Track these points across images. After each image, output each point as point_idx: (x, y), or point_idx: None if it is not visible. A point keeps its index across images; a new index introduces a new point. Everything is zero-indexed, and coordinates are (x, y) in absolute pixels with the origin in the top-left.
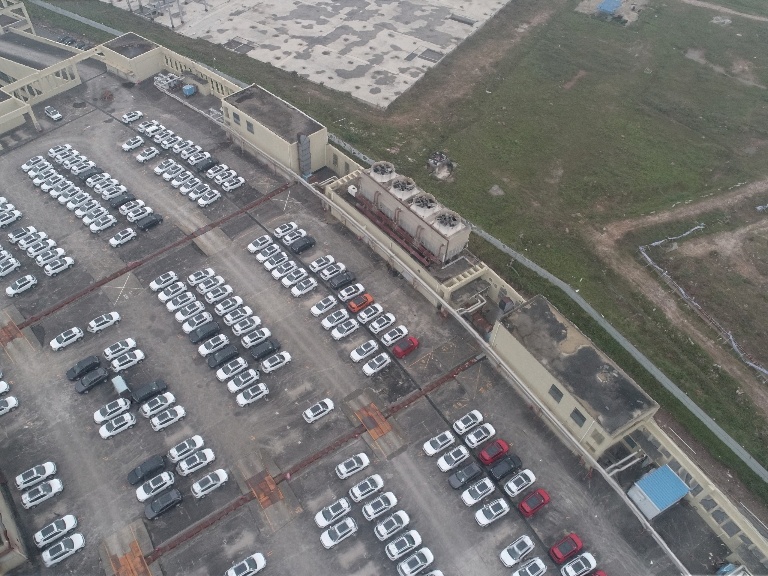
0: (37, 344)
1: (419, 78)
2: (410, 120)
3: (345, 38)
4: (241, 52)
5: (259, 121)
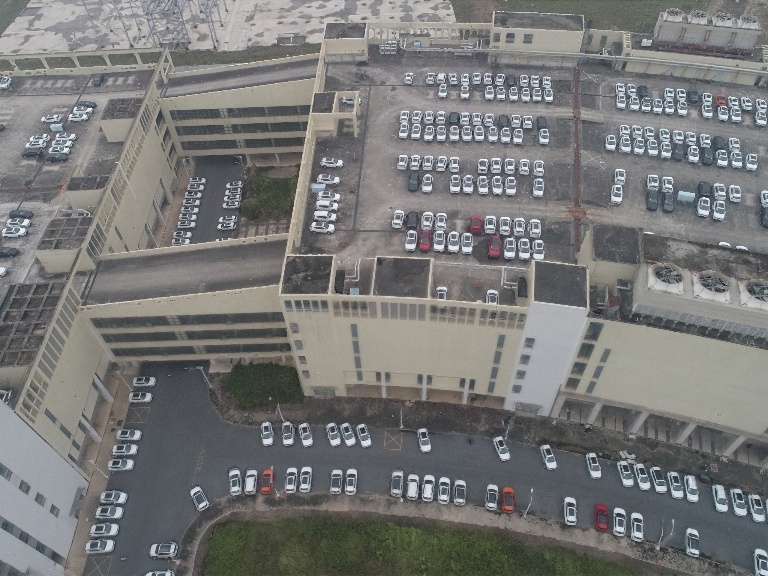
0: (602, 208)
1: (452, 9)
2: None
3: (362, 3)
4: None
5: None
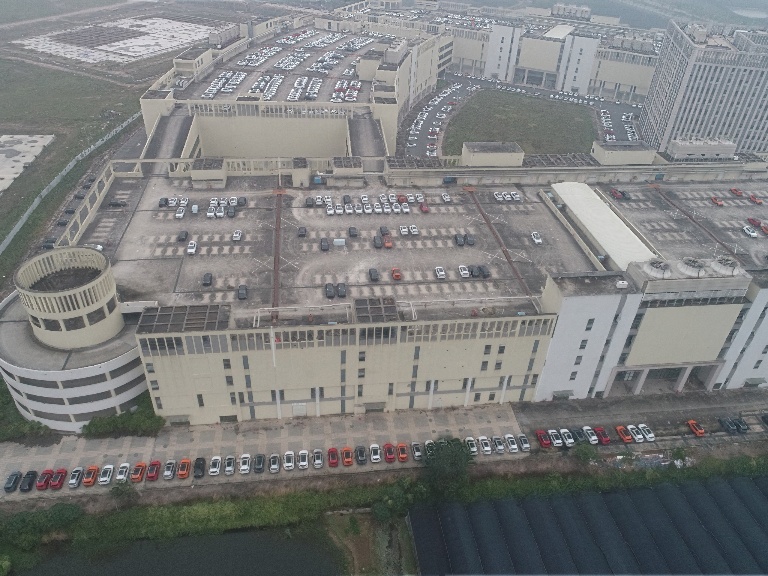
0: None
1: None
2: (64, 129)
3: None
4: (0, 193)
5: None
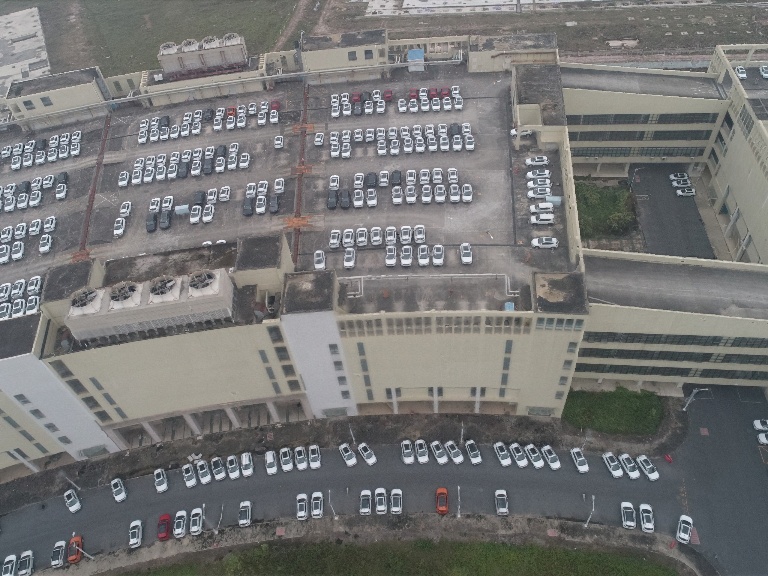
0: (106, 244)
1: None
2: None
3: None
4: None
5: (52, 90)
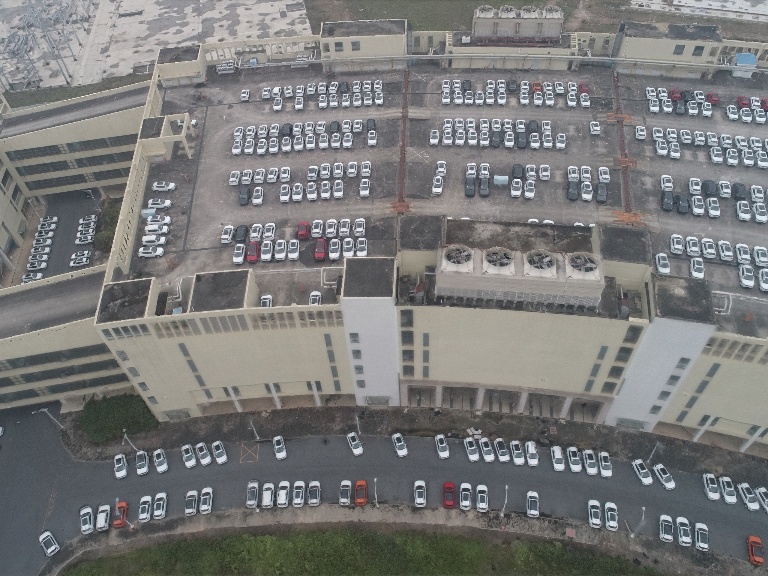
0: (424, 200)
1: (309, 23)
2: None
3: (219, 25)
4: None
5: None
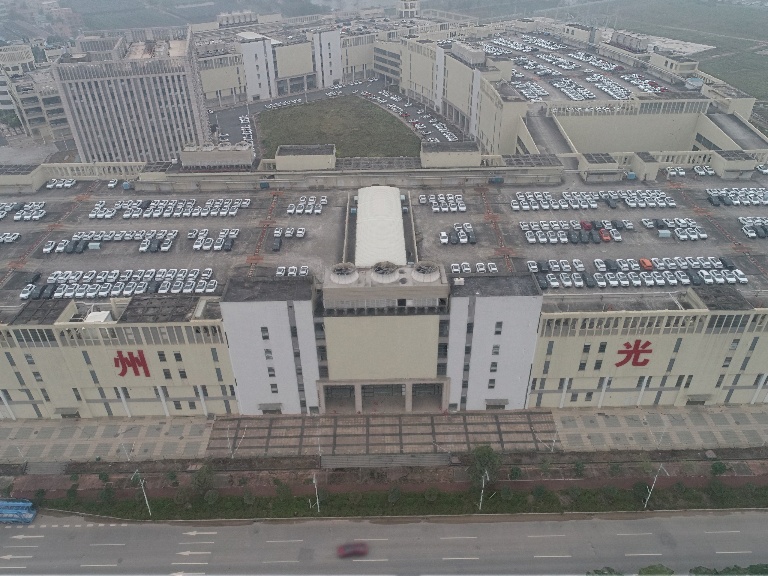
0: None
1: None
2: None
3: None
4: None
5: (577, 28)
